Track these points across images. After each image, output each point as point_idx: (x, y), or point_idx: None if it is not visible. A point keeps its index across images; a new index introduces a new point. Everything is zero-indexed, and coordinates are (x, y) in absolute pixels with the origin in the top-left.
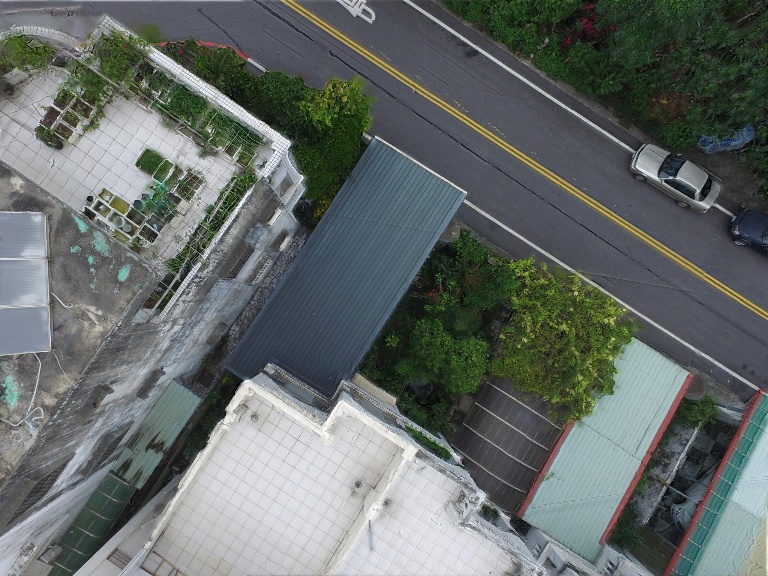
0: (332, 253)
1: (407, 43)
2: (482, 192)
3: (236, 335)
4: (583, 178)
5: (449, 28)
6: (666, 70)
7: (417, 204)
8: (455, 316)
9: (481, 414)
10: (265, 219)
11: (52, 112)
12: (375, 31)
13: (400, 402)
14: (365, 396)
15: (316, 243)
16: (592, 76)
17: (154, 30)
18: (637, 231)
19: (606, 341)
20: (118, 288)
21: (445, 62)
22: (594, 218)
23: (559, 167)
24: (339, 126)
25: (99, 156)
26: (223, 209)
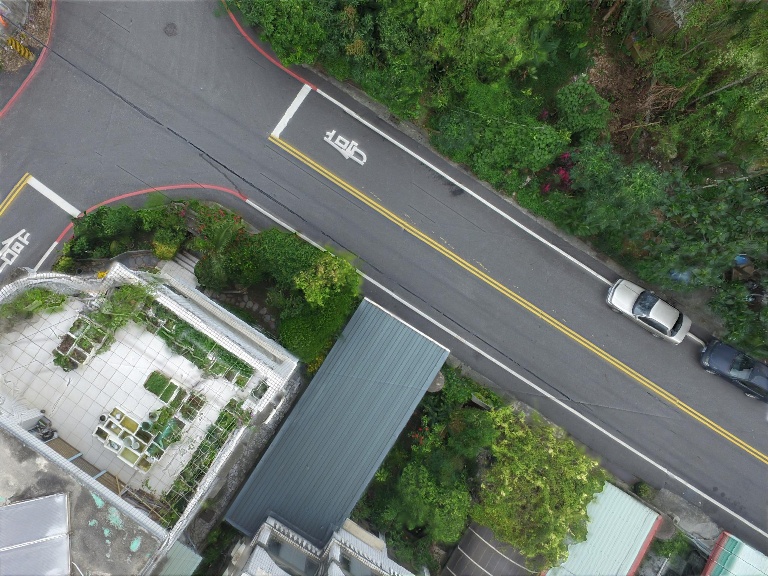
0: (324, 410)
1: (396, 183)
2: (467, 324)
3: (235, 473)
4: (562, 310)
5: (436, 168)
6: (637, 228)
7: (403, 362)
8: (440, 460)
9: (463, 560)
10: (261, 422)
11: (68, 339)
12: (366, 172)
13: (389, 537)
14: (354, 554)
15: (309, 400)
16: (570, 219)
17: (158, 175)
18: (613, 360)
19: (578, 497)
20: (130, 558)
21: (432, 201)
22: (573, 348)
23: (540, 300)
24: (330, 305)
25: (110, 375)
26: (223, 429)
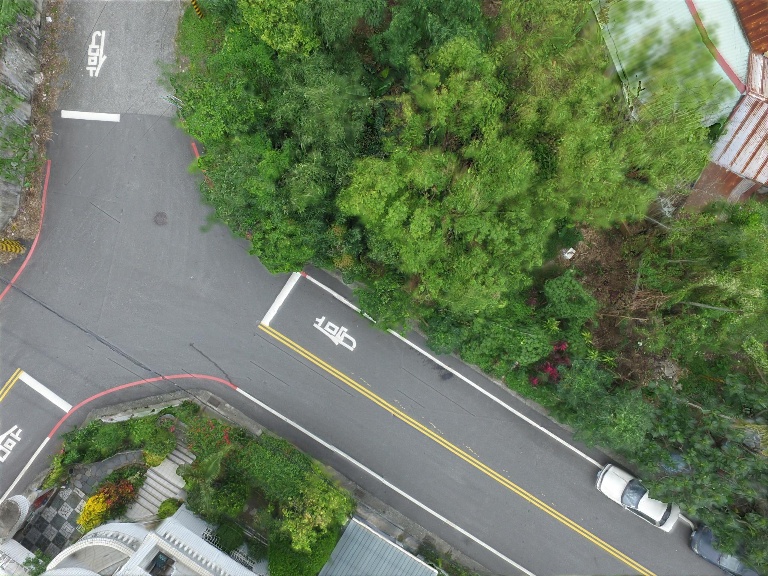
0: None
1: (386, 368)
2: (457, 509)
3: None
4: (552, 493)
5: (425, 352)
6: None
7: None
8: None
9: None
10: None
11: None
12: (356, 358)
13: None
14: None
15: None
16: (558, 411)
17: (149, 365)
18: (603, 544)
19: None
20: None
21: (421, 385)
22: (562, 532)
23: (529, 484)
24: (317, 548)
25: None
26: None
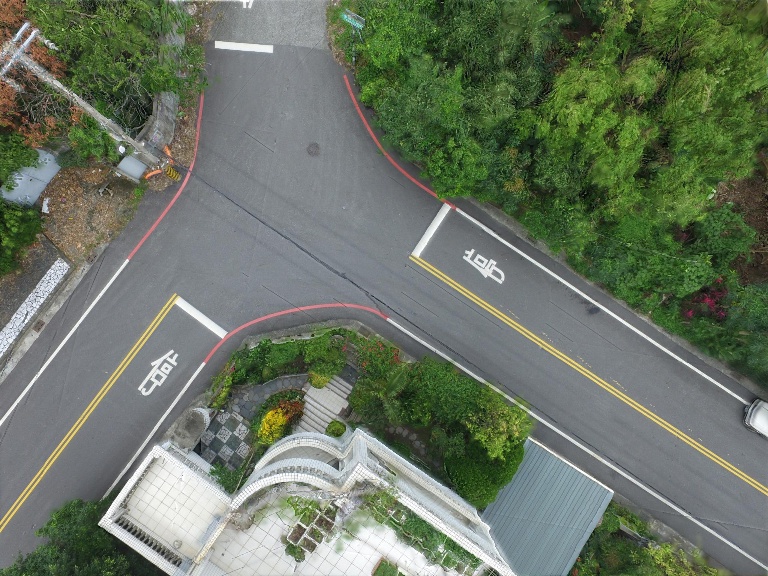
0: None
1: (534, 302)
2: (604, 442)
3: None
4: (698, 428)
5: (573, 287)
6: None
7: (568, 503)
8: None
9: None
10: None
11: None
12: (504, 291)
13: None
14: None
15: None
16: (711, 343)
17: (302, 294)
18: (749, 480)
19: None
20: None
21: (569, 319)
22: (709, 467)
23: (676, 419)
24: (511, 458)
25: (336, 561)
26: None
